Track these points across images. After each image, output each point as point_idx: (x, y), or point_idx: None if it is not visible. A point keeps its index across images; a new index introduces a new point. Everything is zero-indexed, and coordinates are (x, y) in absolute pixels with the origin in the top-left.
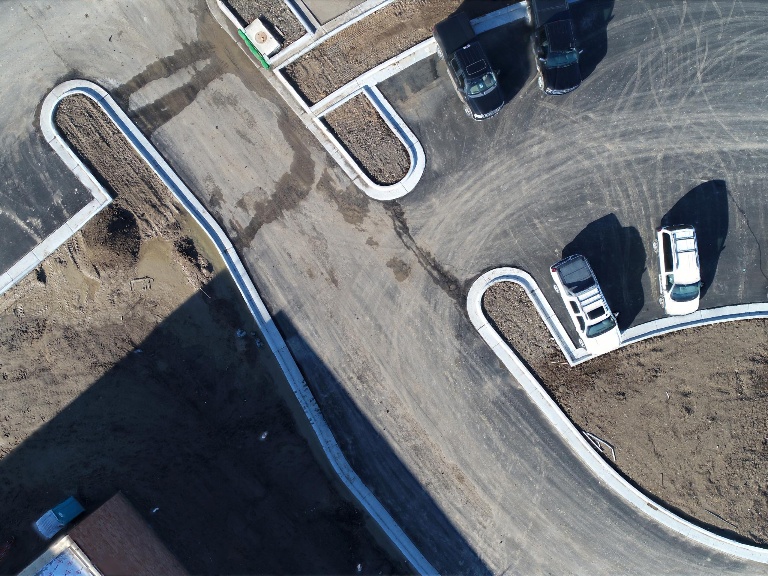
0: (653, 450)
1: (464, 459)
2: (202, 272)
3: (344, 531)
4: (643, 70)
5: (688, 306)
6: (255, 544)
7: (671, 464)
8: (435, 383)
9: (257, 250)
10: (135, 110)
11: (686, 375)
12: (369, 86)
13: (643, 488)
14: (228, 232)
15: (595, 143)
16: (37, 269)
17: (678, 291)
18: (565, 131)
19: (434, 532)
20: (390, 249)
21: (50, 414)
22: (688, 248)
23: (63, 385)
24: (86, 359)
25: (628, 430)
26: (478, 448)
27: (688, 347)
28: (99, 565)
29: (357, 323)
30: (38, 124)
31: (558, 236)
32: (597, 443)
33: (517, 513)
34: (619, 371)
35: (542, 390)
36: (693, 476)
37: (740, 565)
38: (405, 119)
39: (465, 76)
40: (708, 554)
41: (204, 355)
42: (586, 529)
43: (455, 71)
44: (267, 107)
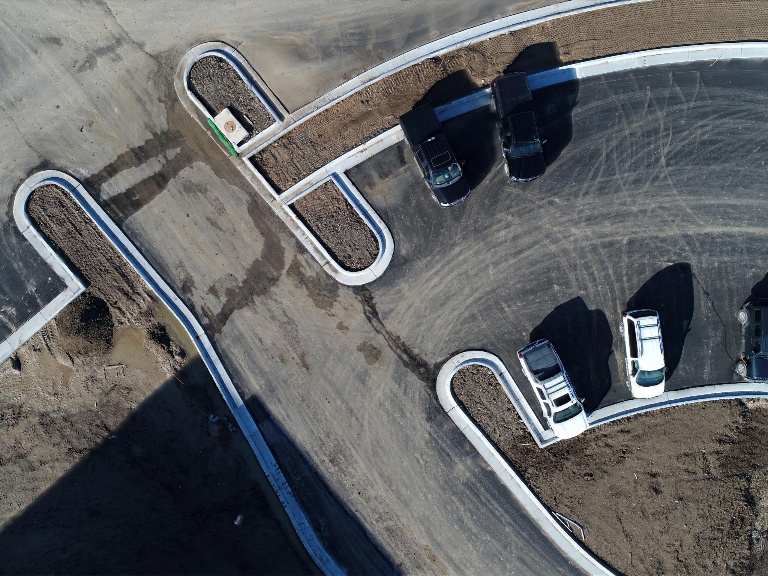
0: (621, 530)
1: (435, 540)
2: (175, 358)
3: None
4: (608, 155)
5: (653, 390)
6: None
7: (639, 543)
8: (406, 465)
9: (229, 336)
10: (107, 199)
11: (653, 456)
12: (337, 173)
13: (612, 567)
14: (200, 318)
15: (561, 227)
16: (12, 357)
17: (643, 376)
18: (531, 216)
19: None
20: (360, 333)
21: (26, 501)
22: (652, 335)
23: (39, 472)
24: (61, 446)
25: (597, 510)
26: (449, 529)
27: (655, 428)
28: None
29: (328, 407)
30: (11, 214)
31: (526, 319)
32: (566, 523)
33: None
34: (587, 452)
35: (511, 471)
36: (661, 555)
37: None
38: (373, 205)
39: (430, 168)
40: None
41: (177, 440)
42: None
43: (421, 162)
44: (237, 195)
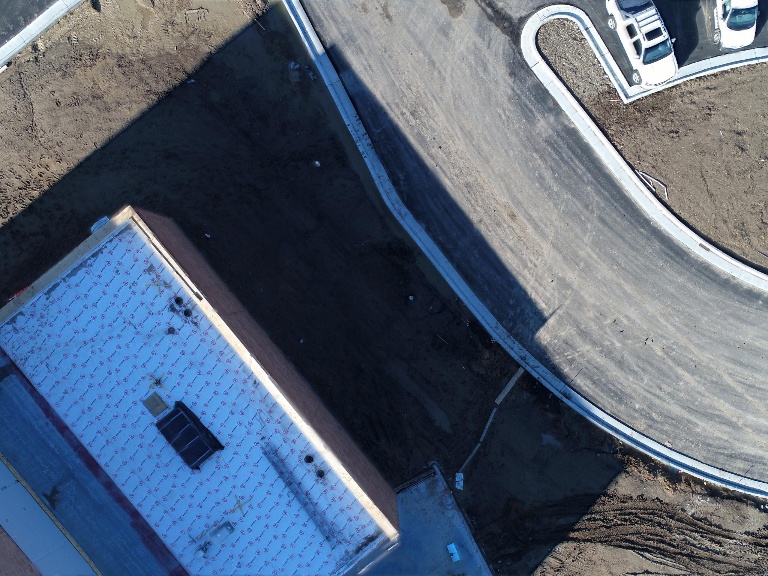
0: (706, 189)
1: (516, 197)
2: (257, 3)
3: (395, 265)
4: None
5: (744, 36)
6: (306, 277)
7: (724, 203)
8: (488, 120)
9: None
10: None
11: (740, 113)
12: None
13: (695, 228)
14: None
15: None
16: None
17: (734, 20)
18: None
19: (485, 270)
20: None
21: (103, 140)
22: None
23: (116, 112)
24: (139, 88)
25: (681, 169)
26: (530, 186)
27: (742, 85)
28: (160, 240)
29: (411, 59)
30: None
31: None
32: (650, 182)
33: (568, 252)
34: (673, 109)
35: (595, 127)
36: (745, 216)
37: None
38: None
39: None
40: (759, 296)
41: (257, 87)
42: (637, 270)
43: None
44: None
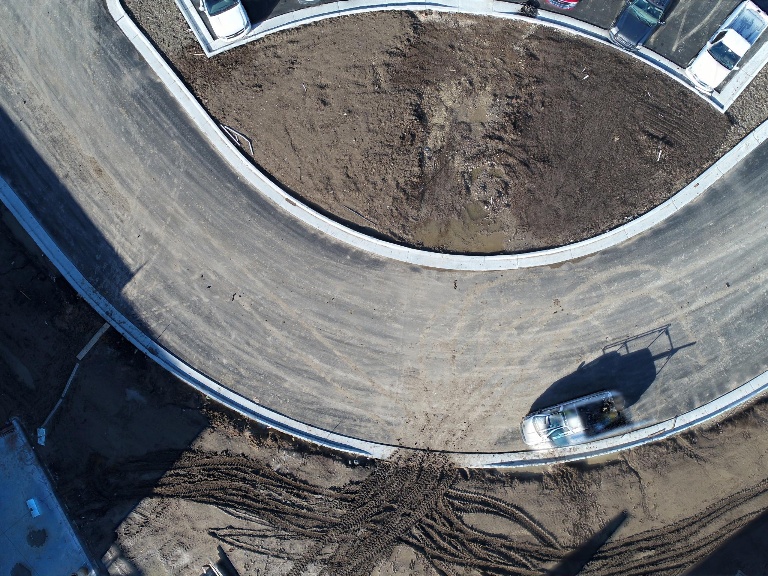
0: (290, 143)
1: (102, 152)
2: None
3: None
4: None
5: None
6: None
7: (308, 158)
8: (73, 75)
9: None
10: None
11: (322, 67)
12: None
13: (281, 183)
14: None
15: None
16: None
17: None
18: None
19: (71, 225)
20: None
21: None
22: None
23: None
24: None
25: (265, 123)
26: (116, 141)
27: (325, 39)
28: None
29: None
30: None
31: None
32: (235, 136)
33: (155, 207)
34: (256, 63)
35: (179, 82)
36: (331, 171)
37: (380, 263)
38: None
39: None
40: (347, 252)
41: None
42: (225, 225)
43: None
44: None
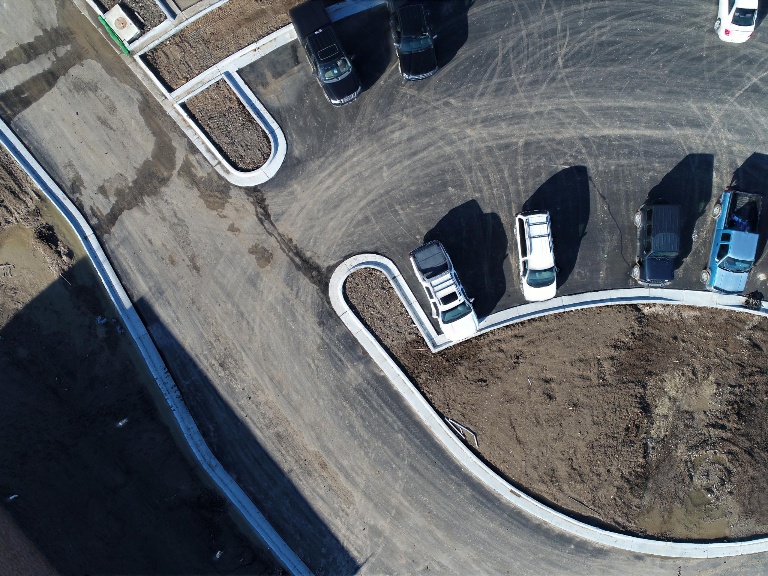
0: (515, 437)
1: (327, 446)
2: (62, 259)
3: (205, 518)
4: (504, 56)
5: (545, 292)
6: (116, 531)
7: (533, 451)
8: (297, 370)
9: (118, 236)
10: None
11: (547, 361)
12: (230, 72)
13: (506, 475)
14: (89, 218)
15: (456, 129)
16: None
17: (534, 277)
18: (426, 117)
19: (297, 519)
20: (252, 235)
21: None
22: (541, 233)
23: None
24: None
25: (490, 417)
26: (341, 435)
27: (549, 333)
28: None
29: (219, 310)
30: None
31: (420, 222)
32: (459, 430)
33: (380, 500)
34: (481, 357)
35: (404, 377)
36: (555, 463)
37: (604, 552)
38: (266, 105)
39: (317, 61)
40: (572, 541)
41: (65, 342)
42: (449, 516)
43: (309, 56)
44: (128, 93)
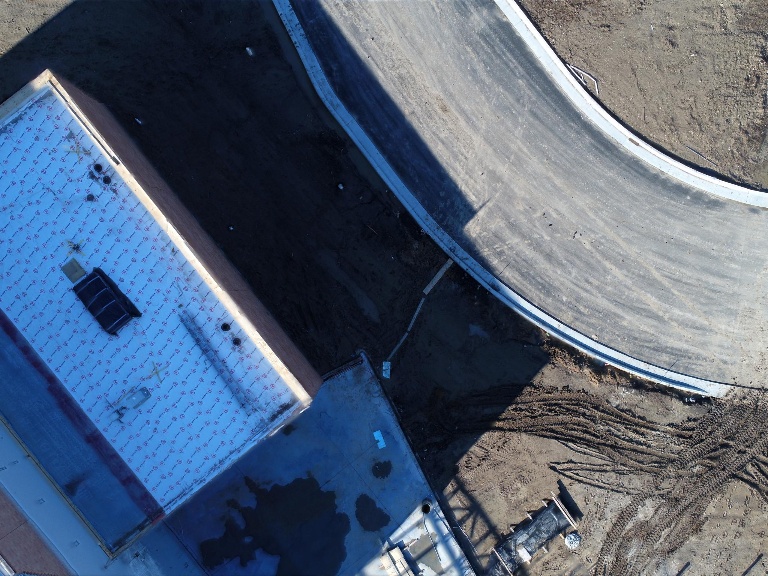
0: (636, 83)
1: (448, 89)
2: None
3: (326, 154)
4: None
5: None
6: (237, 165)
7: (653, 98)
8: (421, 12)
9: None
10: None
11: (671, 8)
12: None
13: (625, 123)
14: None
15: None
16: None
17: None
18: None
19: (416, 162)
20: None
21: (35, 25)
22: None
23: None
24: None
25: (612, 63)
26: (462, 79)
27: None
28: None
29: None
30: None
31: None
32: (580, 76)
33: (499, 145)
34: (604, 3)
35: (527, 20)
36: (675, 111)
37: (719, 204)
38: None
39: None
40: (688, 192)
41: None
42: (567, 164)
43: None
44: None
